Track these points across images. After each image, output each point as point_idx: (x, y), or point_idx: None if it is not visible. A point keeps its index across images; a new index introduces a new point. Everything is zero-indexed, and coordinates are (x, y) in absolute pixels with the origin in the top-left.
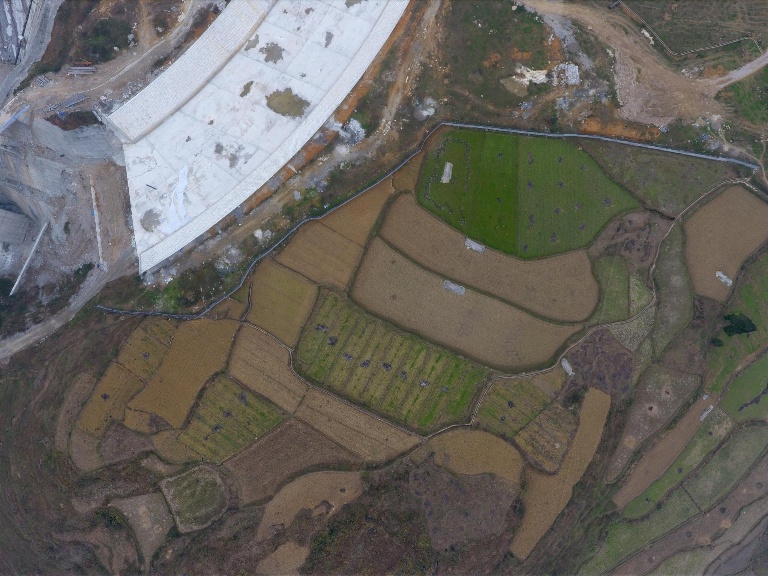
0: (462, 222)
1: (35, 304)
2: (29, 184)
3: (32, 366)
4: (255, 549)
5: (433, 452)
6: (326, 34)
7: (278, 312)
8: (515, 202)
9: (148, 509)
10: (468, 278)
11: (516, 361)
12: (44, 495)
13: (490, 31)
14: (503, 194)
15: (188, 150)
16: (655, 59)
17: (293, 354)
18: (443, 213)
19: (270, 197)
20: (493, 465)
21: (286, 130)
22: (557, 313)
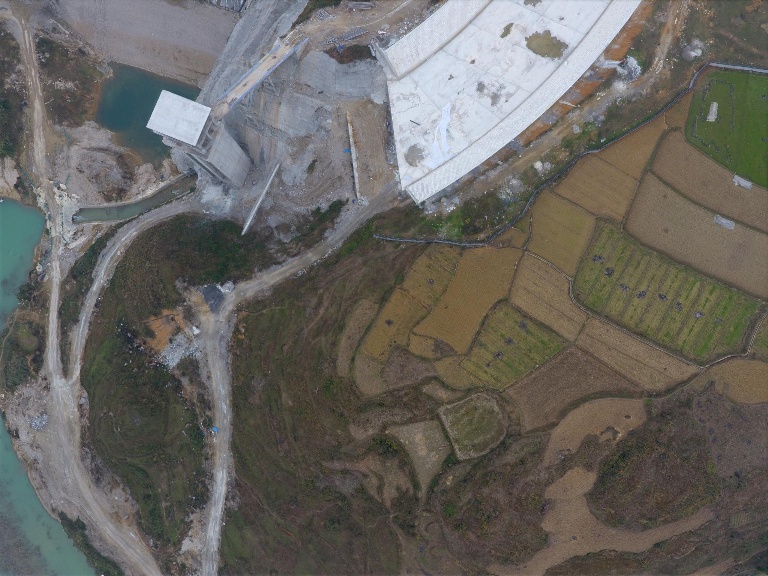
0: (728, 160)
1: (275, 242)
2: (272, 123)
3: (303, 295)
4: (543, 474)
5: (713, 381)
6: None
7: (558, 242)
8: None
9: (424, 436)
10: (737, 214)
11: None
12: (321, 421)
13: None
14: (767, 134)
15: (451, 88)
16: None
17: (572, 283)
18: (710, 151)
19: (549, 130)
20: None
21: (545, 71)
22: None
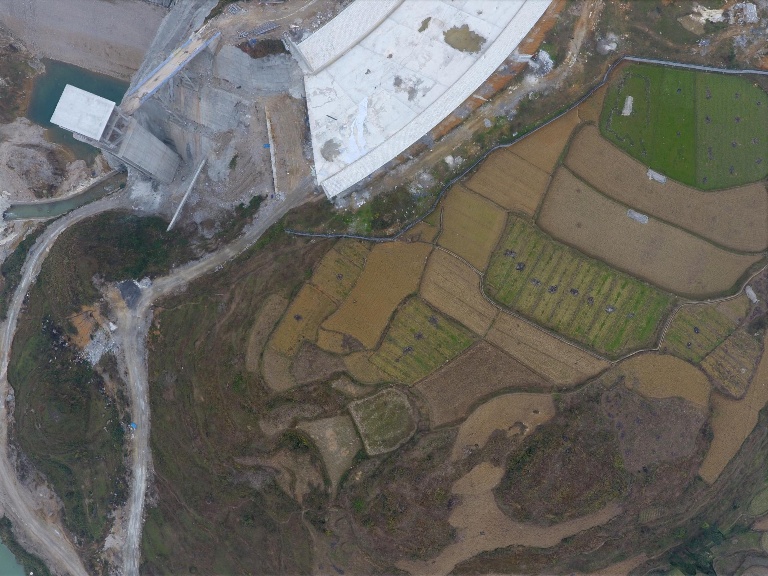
0: (643, 154)
1: (198, 238)
2: (194, 119)
3: (216, 290)
4: (450, 469)
5: (623, 376)
6: None
7: (469, 237)
8: (694, 135)
9: (335, 432)
10: (650, 208)
11: (699, 289)
12: (231, 417)
13: None
14: (682, 128)
15: (368, 82)
16: None
17: (483, 278)
18: (624, 145)
19: (461, 124)
20: (682, 389)
21: (463, 65)
22: (737, 243)
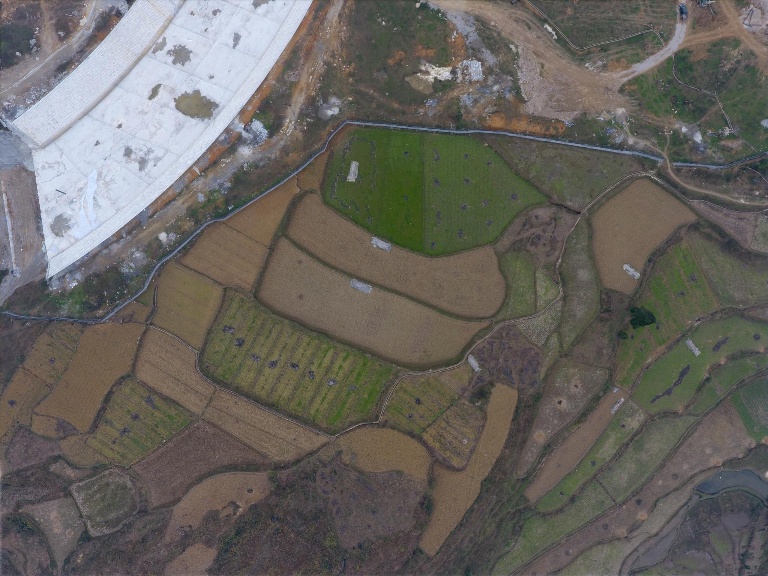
0: (369, 221)
1: None
2: None
3: None
4: (163, 551)
5: (340, 451)
6: (234, 35)
7: (184, 314)
8: (422, 199)
9: (59, 514)
10: (375, 276)
11: (424, 358)
12: None
13: (394, 29)
14: (409, 192)
15: (97, 154)
16: (558, 54)
17: (200, 356)
18: (350, 212)
19: (174, 200)
20: (401, 462)
21: (195, 132)
22: (465, 309)
